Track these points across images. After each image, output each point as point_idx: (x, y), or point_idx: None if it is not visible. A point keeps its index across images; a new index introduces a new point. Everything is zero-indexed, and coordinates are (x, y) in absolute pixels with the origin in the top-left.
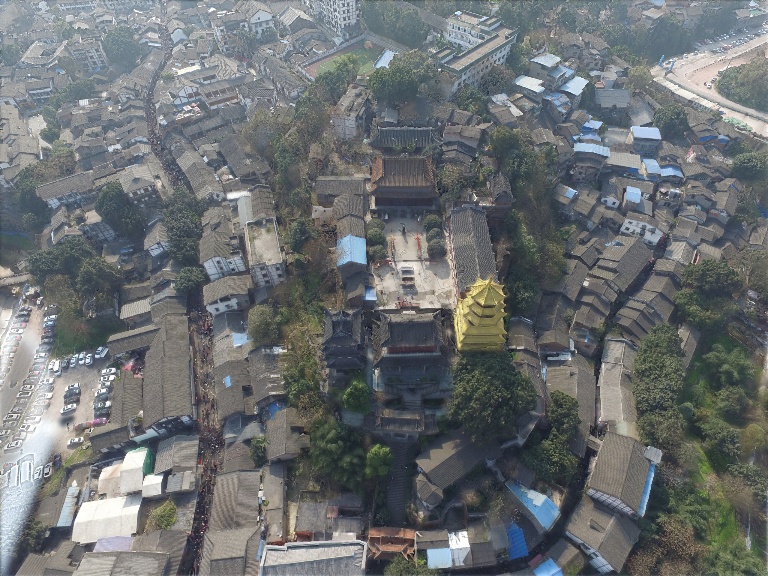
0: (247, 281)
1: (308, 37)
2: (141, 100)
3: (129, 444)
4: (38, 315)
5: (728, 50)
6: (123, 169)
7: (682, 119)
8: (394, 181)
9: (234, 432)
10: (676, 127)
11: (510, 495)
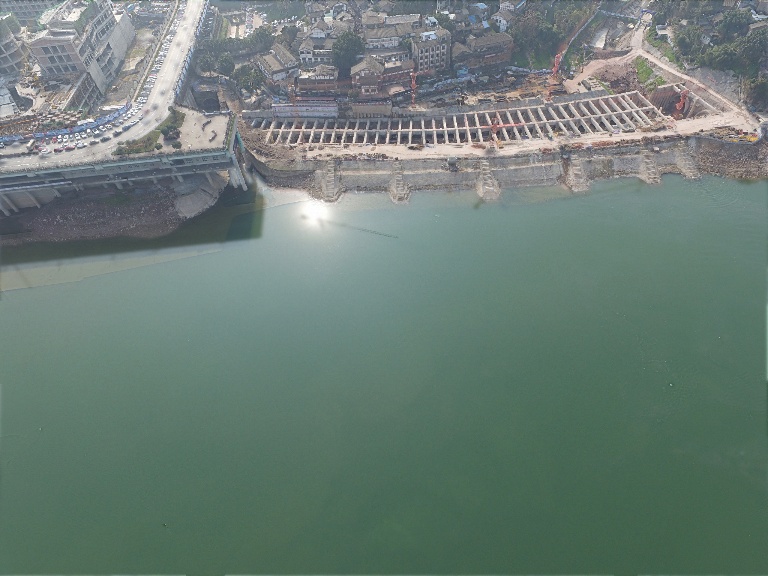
0: None
1: None
2: None
3: None
4: (257, 16)
5: None
6: None
7: None
8: None
9: None
10: None
11: (471, 10)
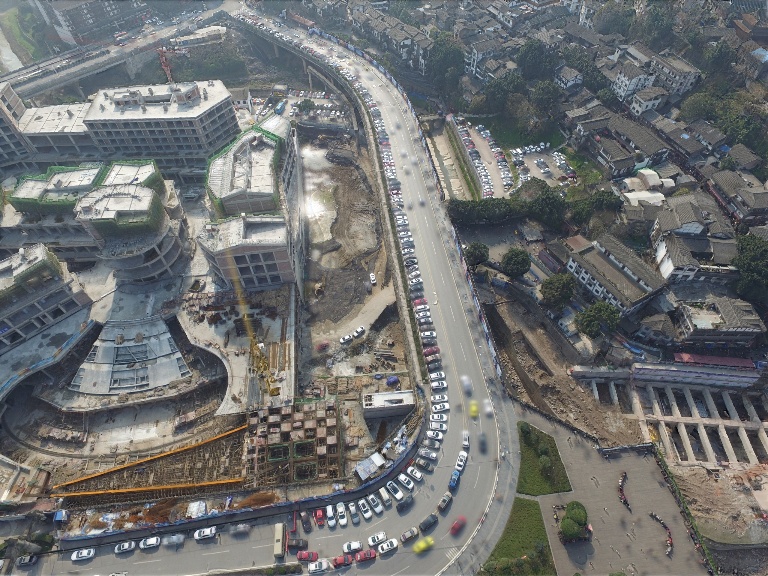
0: (663, 90)
1: None
2: (476, 5)
3: (628, 171)
4: (473, 131)
5: None
6: (511, 40)
7: None
8: (766, 24)
9: (701, 160)
10: None
11: None
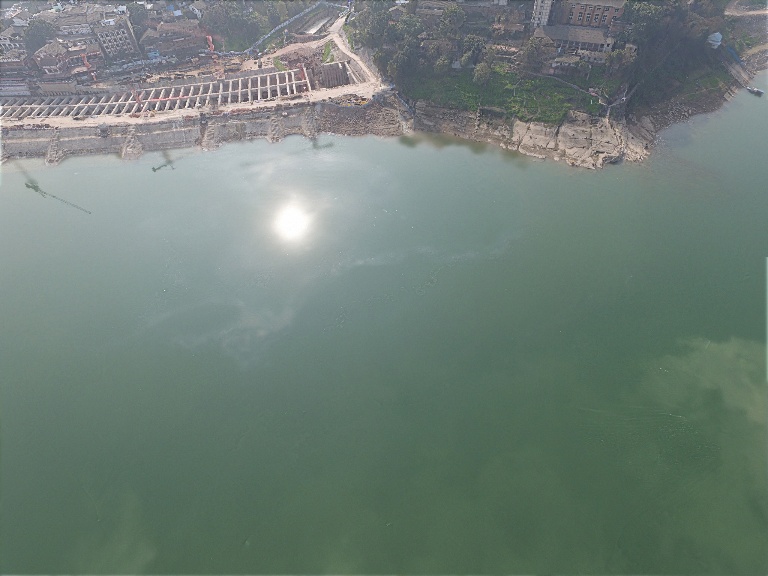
0: None
1: None
2: None
3: None
4: None
5: None
6: None
7: None
8: None
9: None
10: None
11: (173, 1)
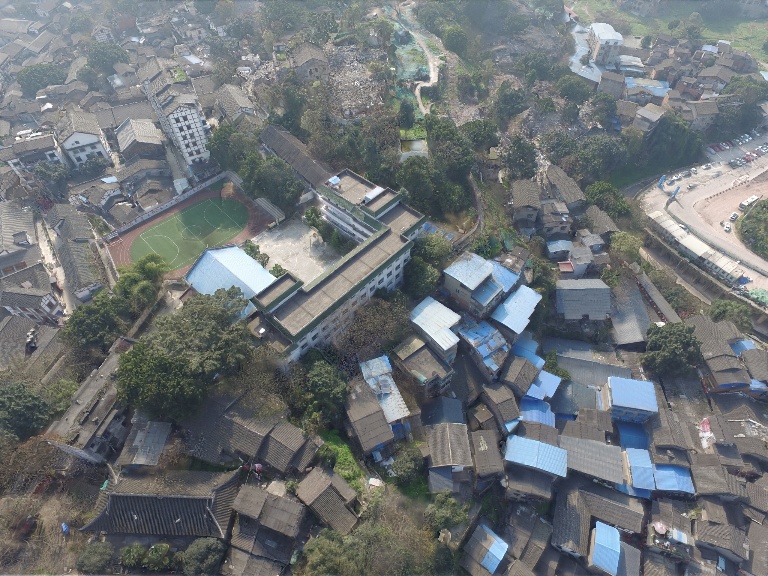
0: None
1: (143, 175)
2: None
3: None
4: None
5: (751, 162)
6: None
7: (692, 352)
8: None
9: None
10: (682, 366)
11: None
